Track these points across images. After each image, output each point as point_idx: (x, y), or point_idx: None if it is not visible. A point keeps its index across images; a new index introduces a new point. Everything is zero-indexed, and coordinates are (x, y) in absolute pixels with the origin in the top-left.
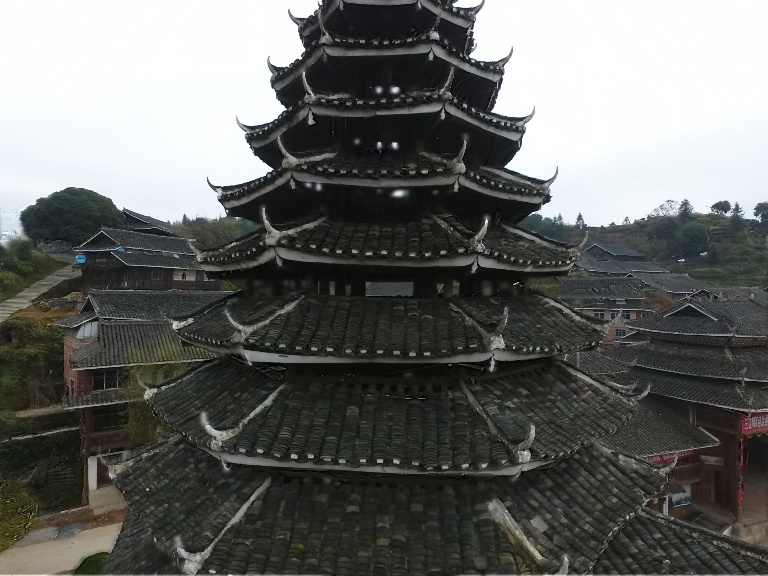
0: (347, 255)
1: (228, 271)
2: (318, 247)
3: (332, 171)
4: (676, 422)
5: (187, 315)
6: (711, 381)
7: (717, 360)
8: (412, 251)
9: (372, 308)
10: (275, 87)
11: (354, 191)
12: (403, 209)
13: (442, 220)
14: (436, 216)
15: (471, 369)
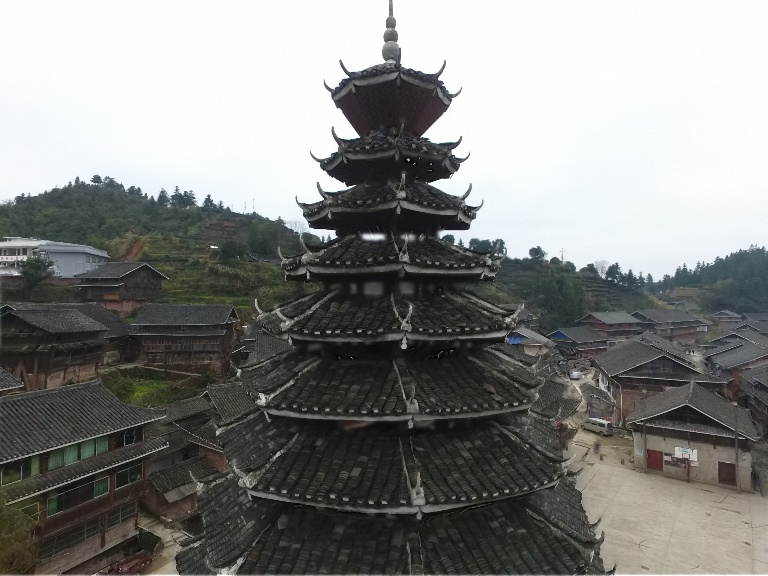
0: (479, 499)
1: (310, 506)
2: (457, 497)
3: (448, 410)
4: None
5: (236, 556)
6: None
7: None
8: (525, 485)
9: (476, 530)
10: (308, 268)
11: (457, 422)
12: (478, 423)
13: (511, 433)
14: (500, 425)
15: None
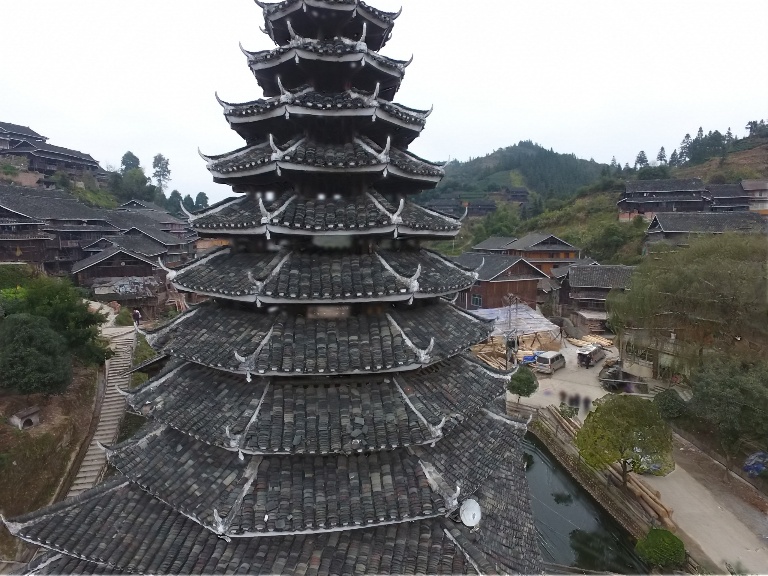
0: None
1: None
2: None
3: None
4: None
5: None
6: None
7: None
8: None
9: None
10: None
11: None
12: None
13: None
14: None
15: None
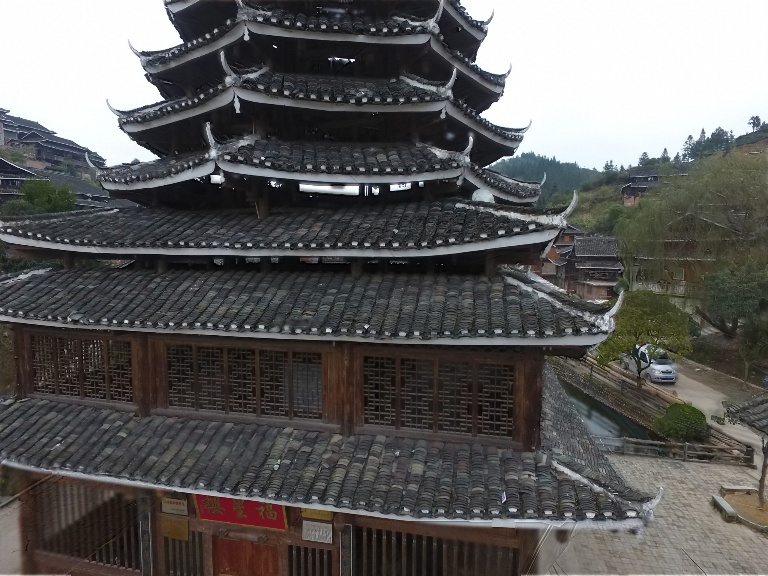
0: None
1: None
2: None
3: None
4: None
5: None
6: None
7: None
8: None
9: None
10: None
11: None
12: None
13: None
14: None
15: (393, 115)
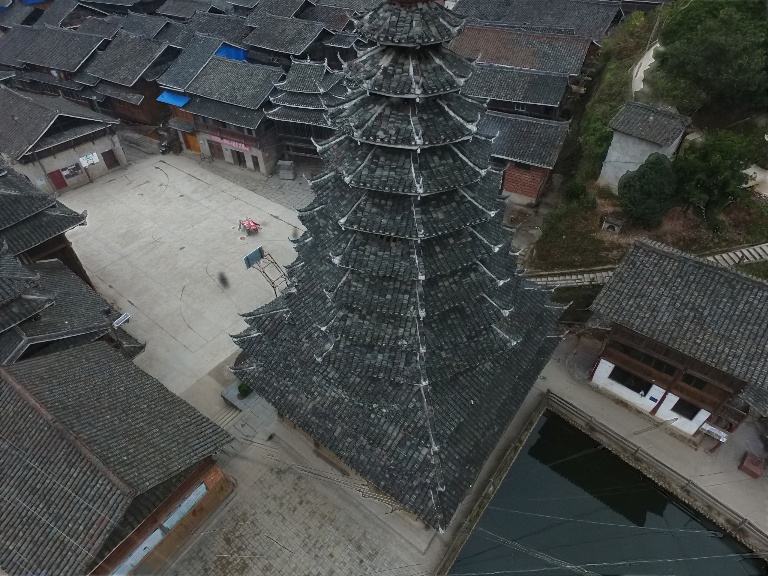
0: None
1: None
2: None
3: None
4: (31, 271)
5: None
6: (24, 220)
7: (4, 201)
8: None
9: None
10: None
11: None
12: None
13: None
14: None
15: None
